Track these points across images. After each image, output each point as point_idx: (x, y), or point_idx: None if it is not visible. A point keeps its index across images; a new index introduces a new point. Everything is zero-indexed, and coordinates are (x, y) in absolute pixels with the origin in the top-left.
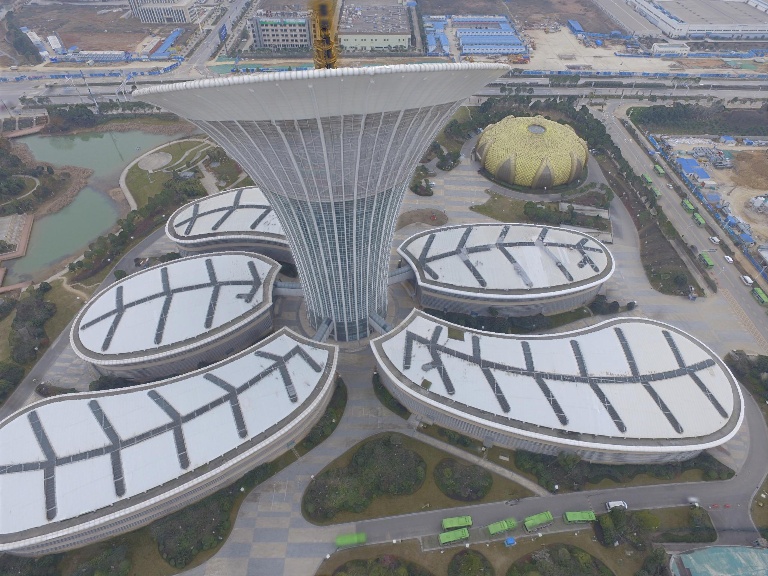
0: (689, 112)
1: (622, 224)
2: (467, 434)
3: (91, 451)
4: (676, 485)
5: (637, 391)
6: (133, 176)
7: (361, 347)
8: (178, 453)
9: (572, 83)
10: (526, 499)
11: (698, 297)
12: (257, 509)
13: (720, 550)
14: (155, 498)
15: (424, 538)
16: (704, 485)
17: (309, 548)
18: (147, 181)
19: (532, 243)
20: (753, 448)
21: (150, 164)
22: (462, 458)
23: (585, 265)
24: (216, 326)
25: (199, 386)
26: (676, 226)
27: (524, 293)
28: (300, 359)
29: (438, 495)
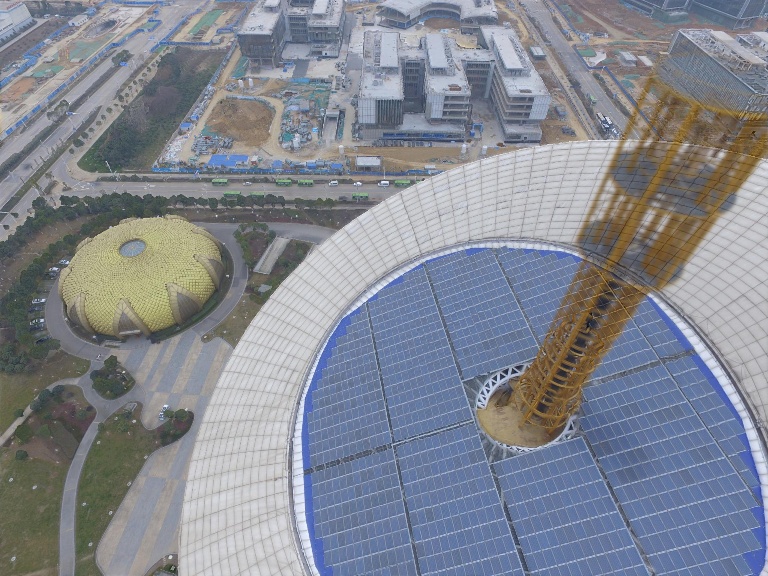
0: (132, 129)
1: (300, 232)
2: None
3: None
4: None
5: None
6: None
7: None
8: None
9: None
10: None
11: None
12: None
13: None
14: None
15: None
16: None
17: None
18: None
19: None
20: None
21: None
22: None
23: None
24: None
25: None
26: None
27: None
28: None
29: None
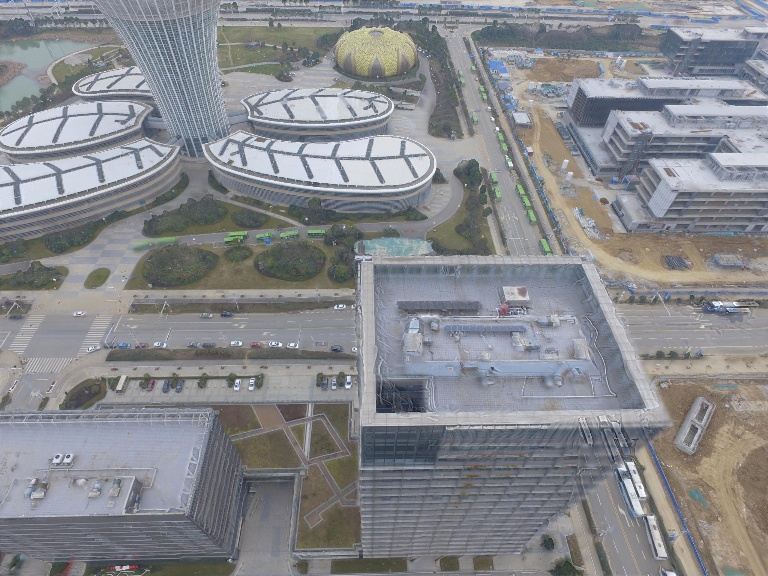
0: (515, 31)
1: (427, 100)
2: (262, 200)
3: (1, 184)
4: (387, 223)
5: (364, 164)
6: (58, 68)
7: (206, 160)
8: (57, 187)
9: (437, 12)
10: (288, 228)
11: (458, 139)
12: (113, 231)
13: (388, 239)
14: (40, 207)
15: (216, 243)
16: (405, 223)
17: (142, 246)
18: (69, 70)
19: (335, 96)
20: (447, 208)
21: (74, 61)
22: (255, 211)
23: (369, 109)
24: (97, 135)
25: (78, 160)
26: (467, 102)
27: (320, 123)
28: (150, 150)
29: (232, 225)
